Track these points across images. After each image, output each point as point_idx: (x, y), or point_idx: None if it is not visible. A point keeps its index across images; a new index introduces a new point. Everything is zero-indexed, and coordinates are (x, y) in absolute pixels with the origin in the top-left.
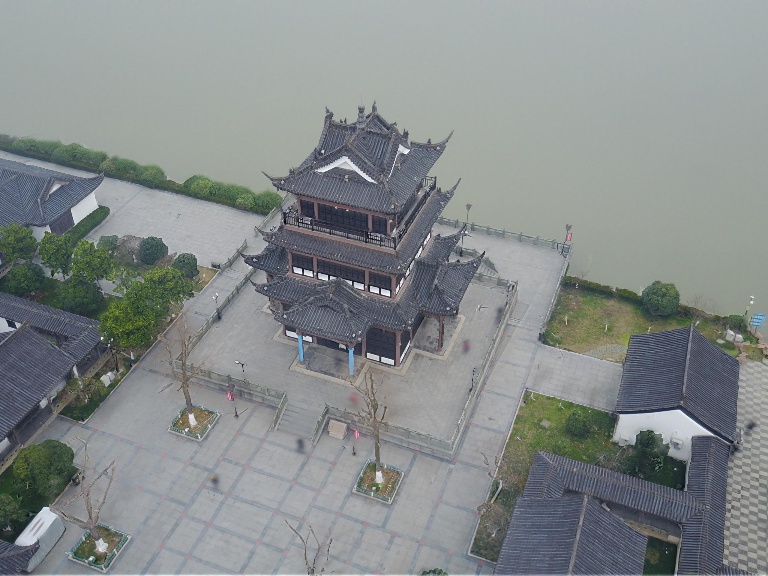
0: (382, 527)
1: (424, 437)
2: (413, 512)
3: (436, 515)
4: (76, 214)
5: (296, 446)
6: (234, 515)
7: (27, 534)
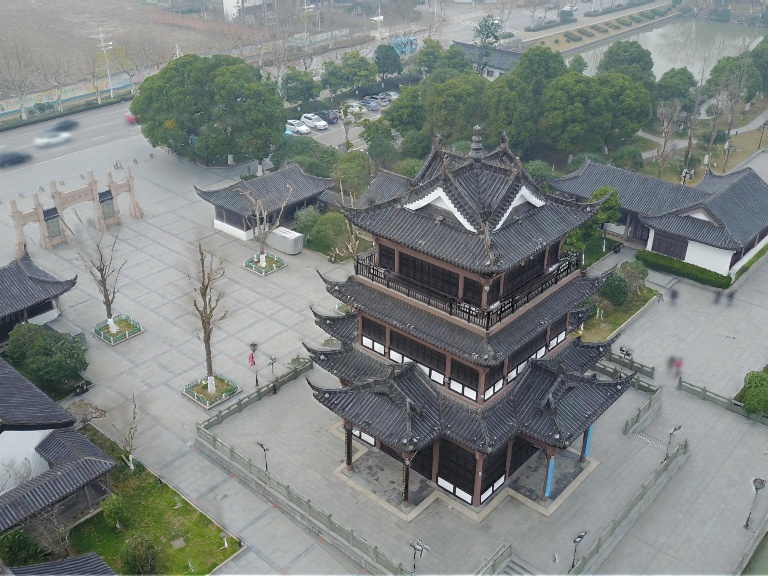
0: (166, 383)
1: (224, 412)
2: (163, 404)
3: (147, 416)
4: (692, 253)
5: (293, 355)
6: (246, 316)
7: (283, 229)
